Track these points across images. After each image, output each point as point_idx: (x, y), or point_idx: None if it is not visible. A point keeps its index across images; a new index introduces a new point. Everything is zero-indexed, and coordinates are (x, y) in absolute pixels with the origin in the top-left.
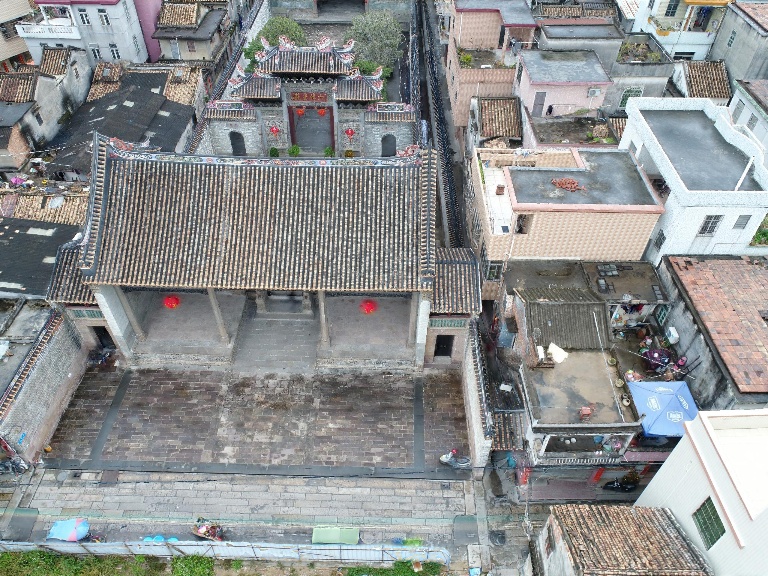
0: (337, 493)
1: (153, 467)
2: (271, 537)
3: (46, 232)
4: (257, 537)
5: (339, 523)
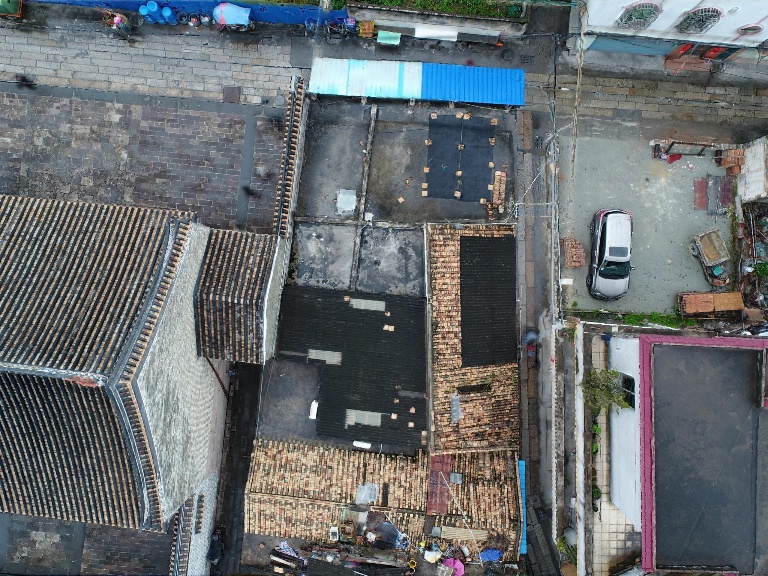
0: (5, 65)
1: (189, 103)
2: (67, 26)
3: (356, 418)
4: (80, 27)
5: (4, 35)
